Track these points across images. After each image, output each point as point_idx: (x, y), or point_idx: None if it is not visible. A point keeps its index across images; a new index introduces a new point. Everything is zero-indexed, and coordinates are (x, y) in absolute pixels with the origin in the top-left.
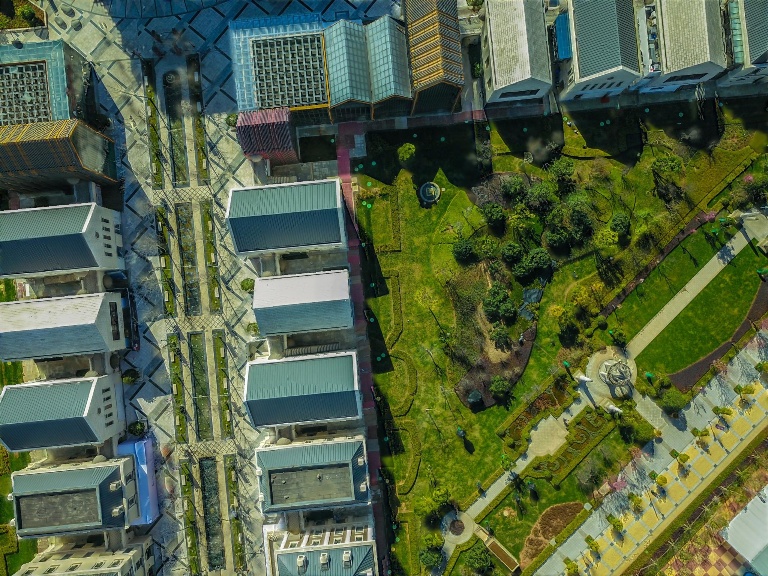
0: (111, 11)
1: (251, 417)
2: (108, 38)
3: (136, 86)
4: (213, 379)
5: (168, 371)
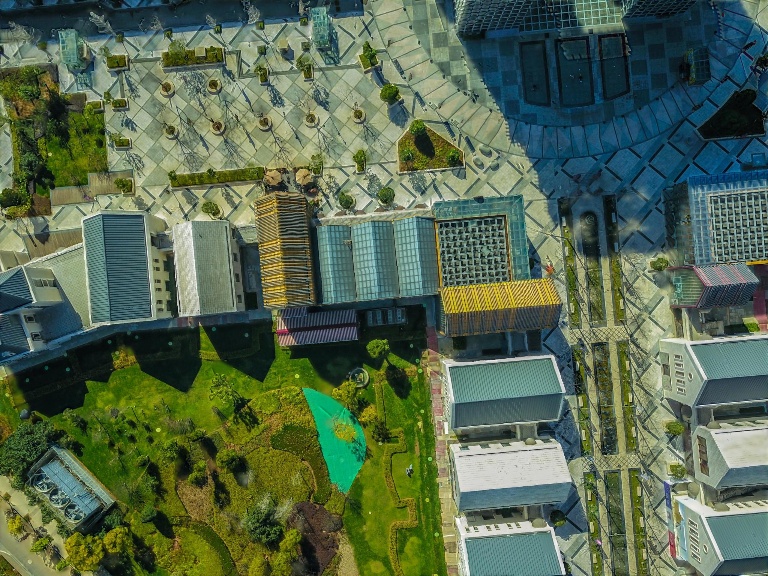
0: (528, 151)
1: (715, 572)
2: (525, 178)
3: (553, 226)
4: (629, 517)
5: (585, 509)
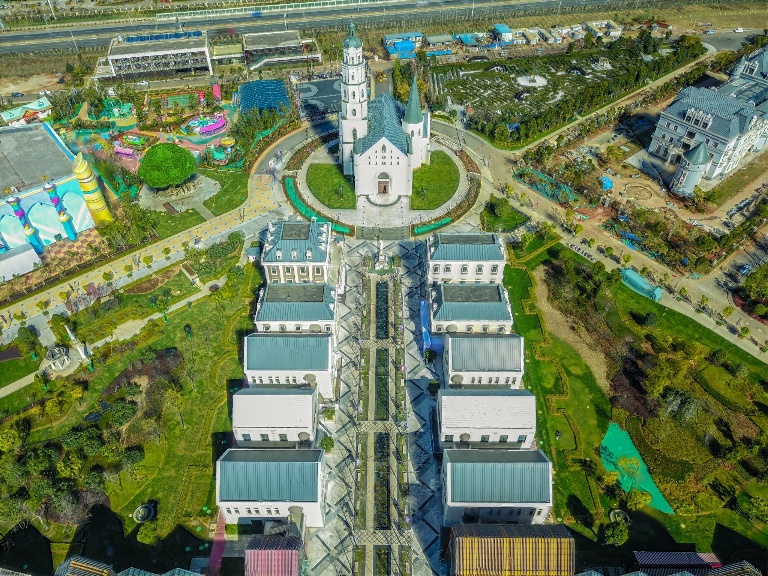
0: None
1: None
2: None
3: None
4: (372, 387)
5: (407, 395)
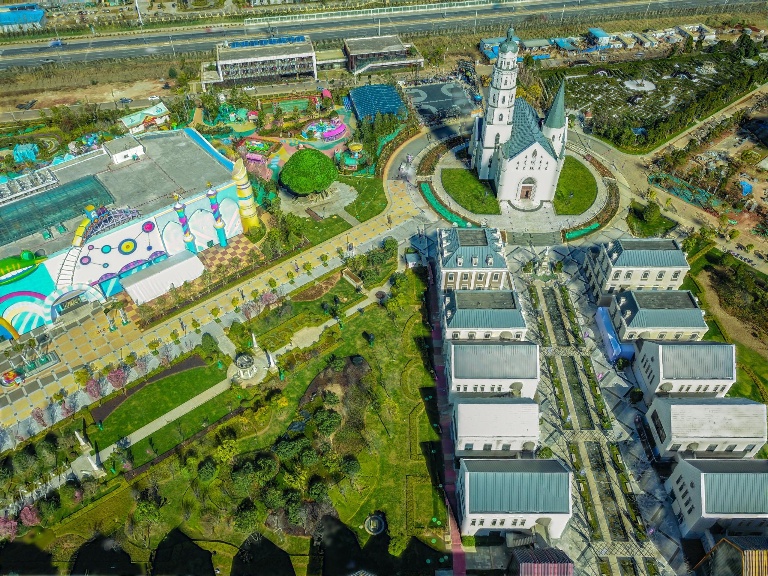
0: None
1: None
2: None
3: None
4: (567, 395)
5: (606, 403)
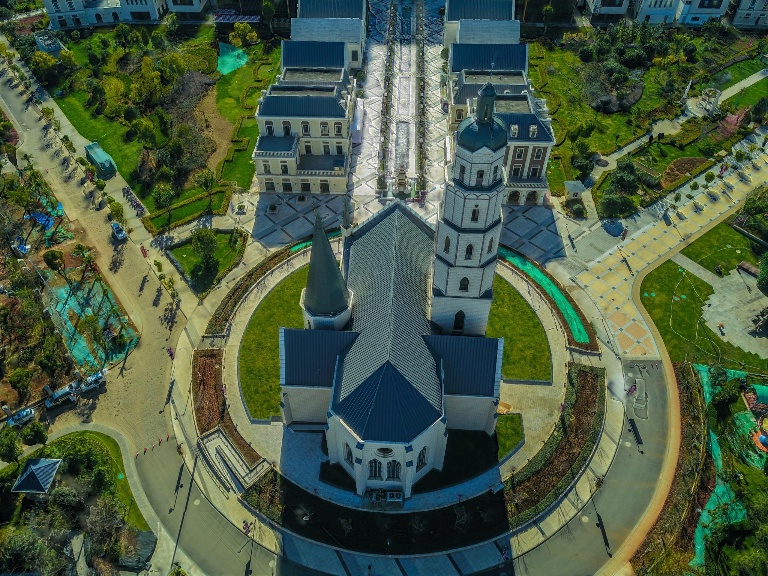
0: None
1: (452, 61)
2: None
3: None
4: (413, 93)
5: (383, 88)
